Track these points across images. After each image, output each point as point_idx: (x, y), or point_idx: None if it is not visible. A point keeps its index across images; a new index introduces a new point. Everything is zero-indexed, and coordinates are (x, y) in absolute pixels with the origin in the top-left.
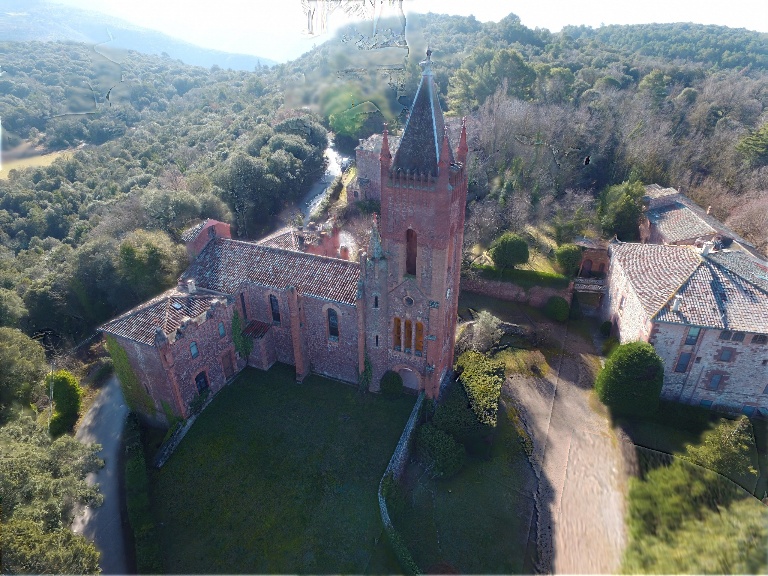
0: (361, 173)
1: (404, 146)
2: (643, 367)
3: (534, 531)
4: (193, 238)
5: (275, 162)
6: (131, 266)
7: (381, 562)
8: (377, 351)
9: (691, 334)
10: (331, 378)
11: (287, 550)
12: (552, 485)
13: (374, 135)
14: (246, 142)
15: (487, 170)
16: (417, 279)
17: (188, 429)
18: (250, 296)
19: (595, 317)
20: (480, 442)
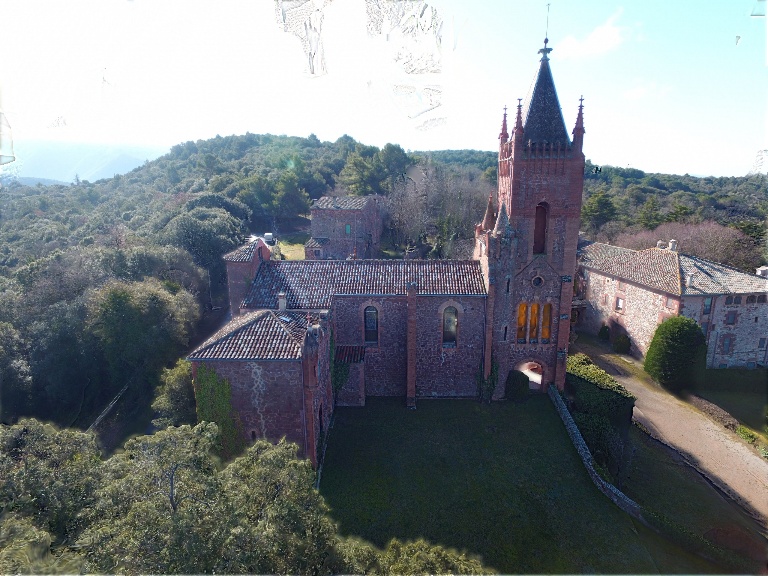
0: (317, 233)
1: (531, 122)
2: (693, 334)
3: (719, 490)
4: (250, 257)
5: (219, 226)
6: (123, 319)
7: (659, 550)
8: (505, 346)
9: (706, 304)
10: (443, 398)
11: (561, 574)
12: (690, 451)
13: (323, 197)
14: (151, 221)
15: (433, 225)
16: (548, 255)
17: (318, 486)
18: (337, 315)
19: (581, 331)
20: (624, 422)
